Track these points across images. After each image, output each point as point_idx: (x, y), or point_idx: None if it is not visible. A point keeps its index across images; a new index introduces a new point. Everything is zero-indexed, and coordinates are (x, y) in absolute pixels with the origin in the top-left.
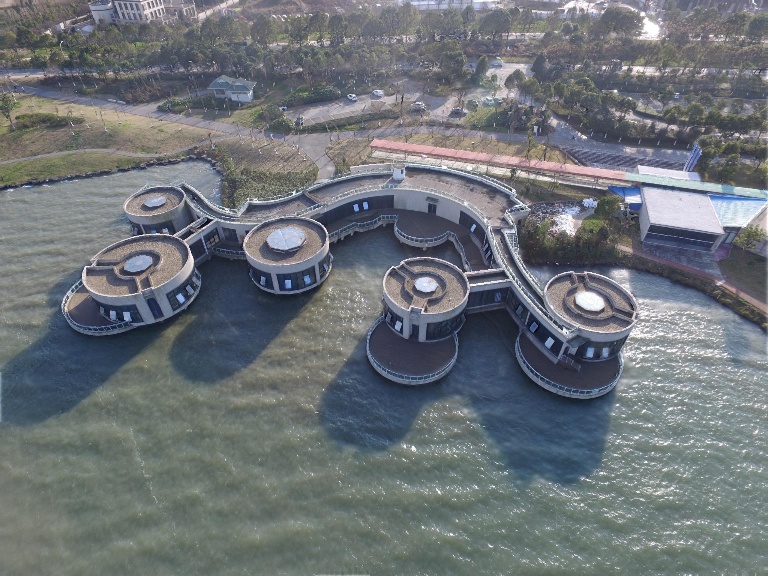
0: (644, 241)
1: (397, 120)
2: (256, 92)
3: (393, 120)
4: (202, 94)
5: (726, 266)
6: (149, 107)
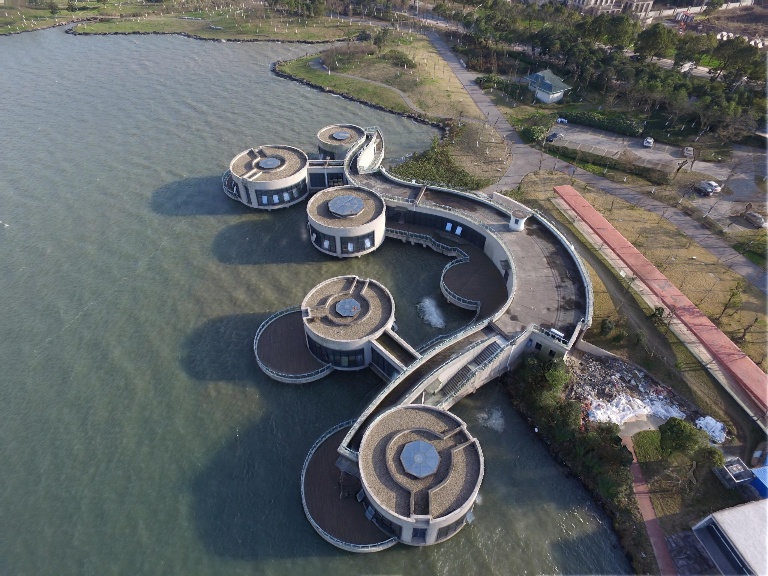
0: (695, 532)
1: (654, 186)
2: (565, 97)
3: (649, 184)
4: (526, 81)
5: None
6: (474, 76)
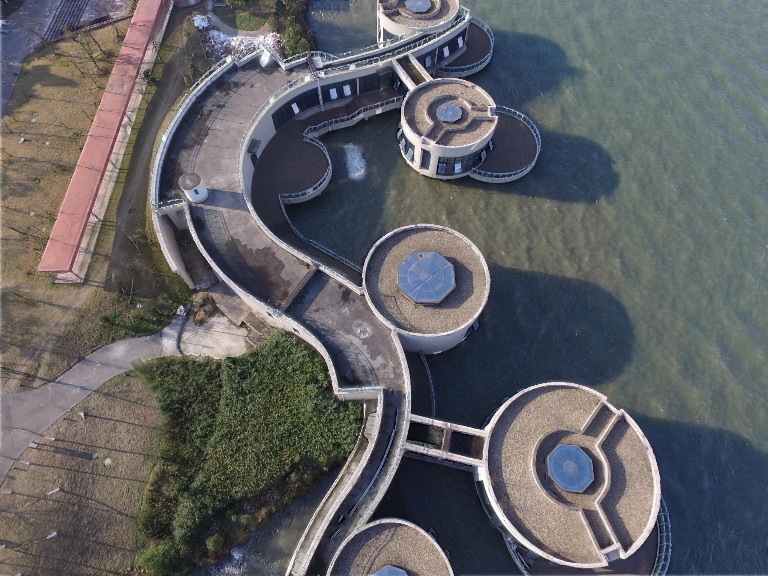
0: None
1: None
2: None
3: None
4: None
5: None
6: None
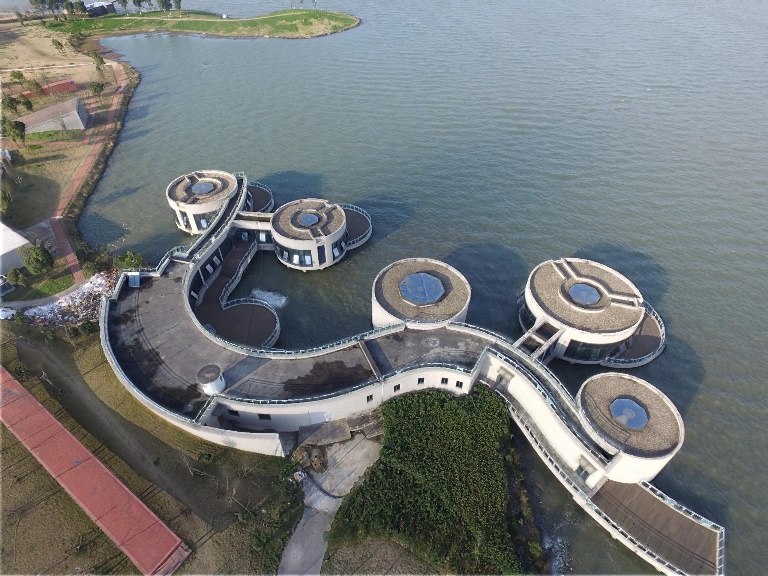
0: None
1: None
2: None
3: None
4: None
5: (27, 224)
6: None
